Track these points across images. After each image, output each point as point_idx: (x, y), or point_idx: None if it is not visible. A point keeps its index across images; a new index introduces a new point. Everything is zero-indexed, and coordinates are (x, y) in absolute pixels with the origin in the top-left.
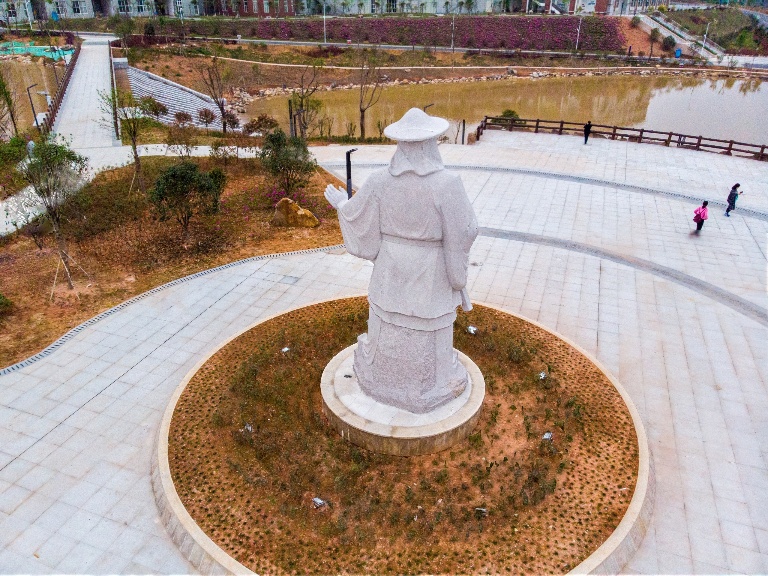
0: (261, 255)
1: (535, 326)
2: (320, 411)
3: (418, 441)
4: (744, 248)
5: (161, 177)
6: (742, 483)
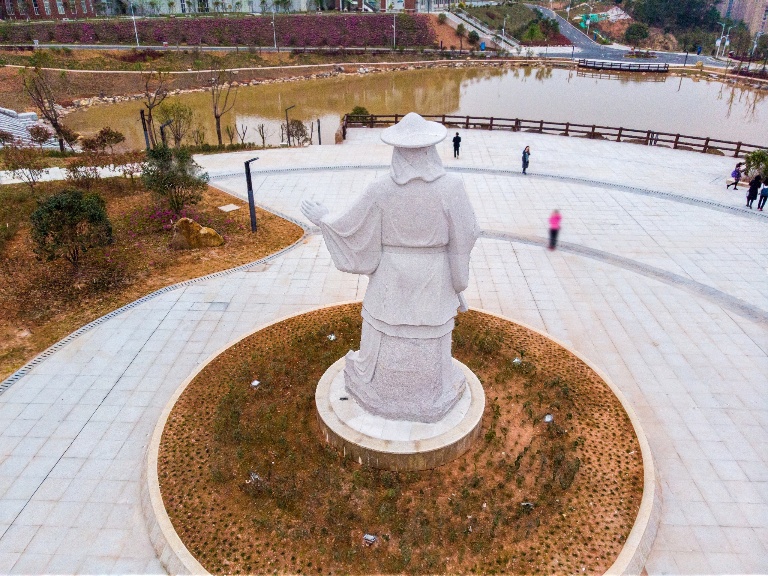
0: (173, 284)
1: (488, 315)
2: (324, 442)
3: (443, 451)
4: (619, 217)
5: (42, 210)
6: (711, 424)
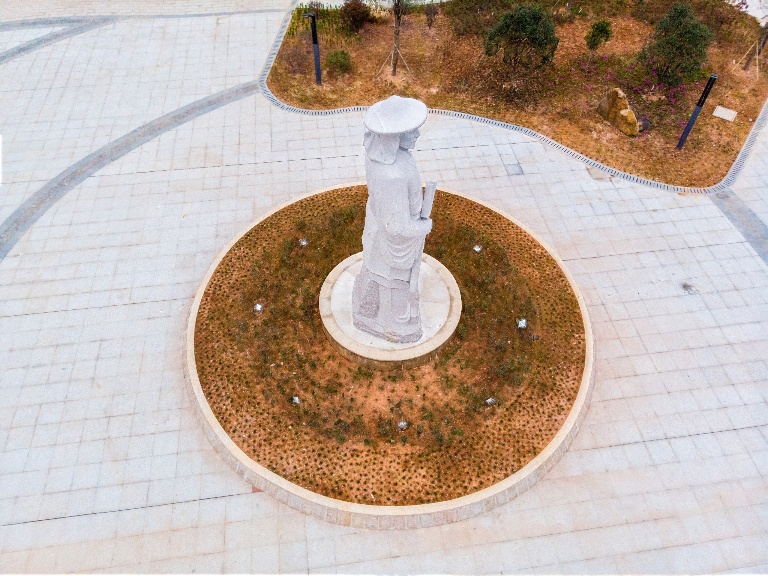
0: (538, 132)
1: (581, 375)
2: None
3: None
4: None
5: None
6: None
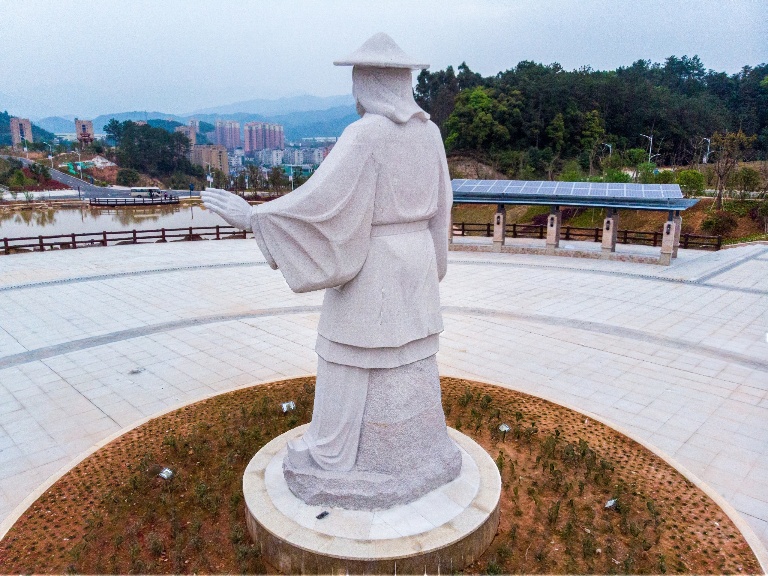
0: None
1: None
2: None
3: None
4: None
5: None
6: (575, 384)
